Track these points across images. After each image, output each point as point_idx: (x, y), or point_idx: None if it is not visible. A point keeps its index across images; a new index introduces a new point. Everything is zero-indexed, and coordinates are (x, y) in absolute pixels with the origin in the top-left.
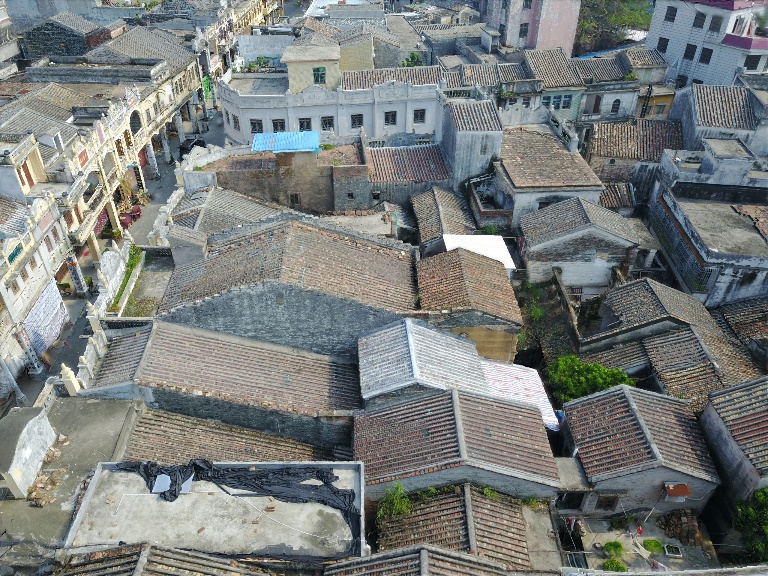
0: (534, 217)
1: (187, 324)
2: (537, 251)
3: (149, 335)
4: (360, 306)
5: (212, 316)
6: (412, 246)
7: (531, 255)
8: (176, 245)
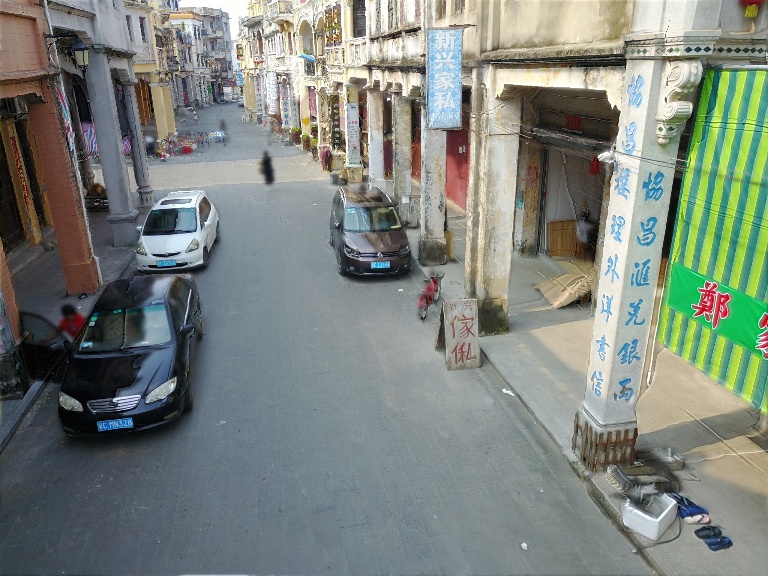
0: None
1: None
2: None
3: None
4: None
5: None
6: None
7: None
8: None
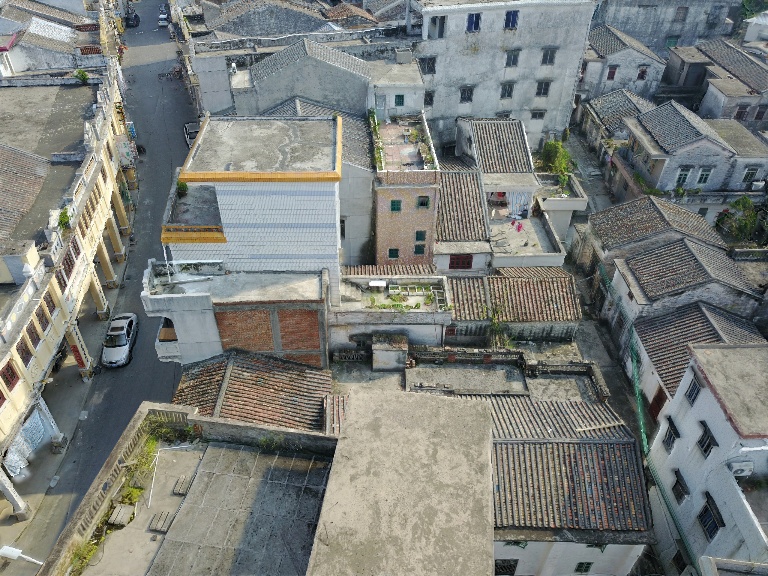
0: (374, 3)
1: (229, 32)
2: (378, 15)
3: (215, 35)
4: (308, 16)
5: (241, 27)
6: (319, 7)
7: (376, 18)
8: (206, 8)
